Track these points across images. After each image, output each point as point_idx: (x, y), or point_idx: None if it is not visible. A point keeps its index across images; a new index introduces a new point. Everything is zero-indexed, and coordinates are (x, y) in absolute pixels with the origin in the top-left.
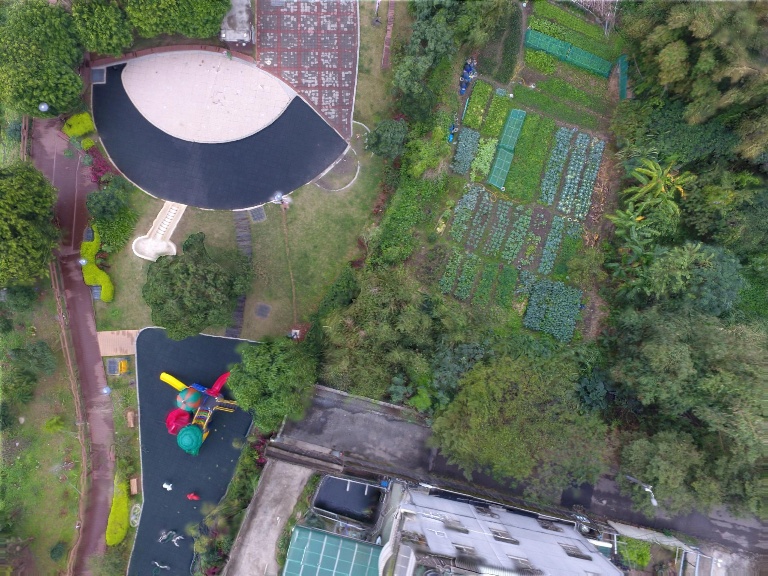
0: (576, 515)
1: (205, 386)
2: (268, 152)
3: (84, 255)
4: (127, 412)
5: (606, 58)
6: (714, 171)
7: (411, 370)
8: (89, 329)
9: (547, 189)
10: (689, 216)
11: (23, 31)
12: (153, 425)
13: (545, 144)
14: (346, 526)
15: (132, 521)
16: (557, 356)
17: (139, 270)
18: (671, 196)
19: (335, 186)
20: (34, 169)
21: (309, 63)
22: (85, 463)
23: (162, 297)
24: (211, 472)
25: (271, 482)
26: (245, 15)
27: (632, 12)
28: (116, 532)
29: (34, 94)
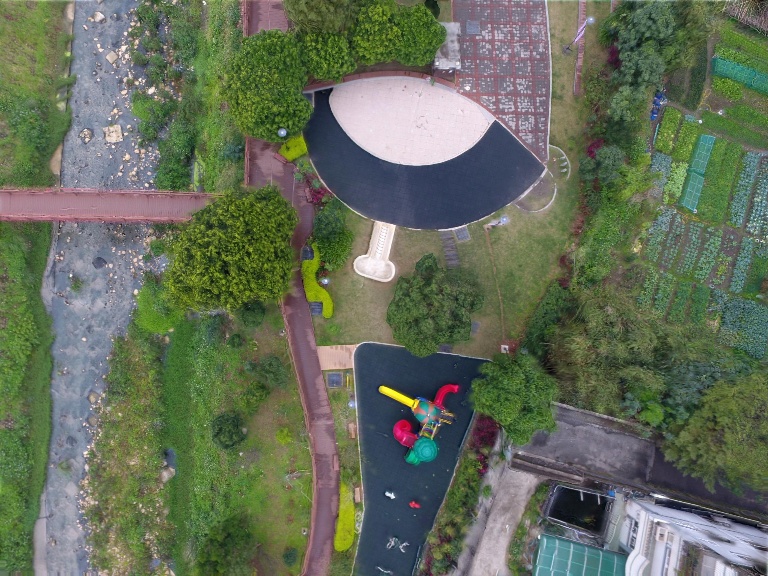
0: None
1: None
2: (470, 174)
3: (305, 273)
4: (348, 423)
5: None
6: None
7: (640, 386)
8: (309, 344)
9: (735, 211)
10: None
11: (263, 60)
12: (372, 436)
13: (733, 168)
14: (579, 534)
15: (355, 528)
16: (757, 372)
17: (360, 288)
18: None
19: (534, 207)
20: None
21: (505, 89)
22: (314, 472)
23: (414, 316)
24: (428, 481)
25: (500, 491)
26: (456, 44)
27: None
28: (345, 539)
29: (276, 121)
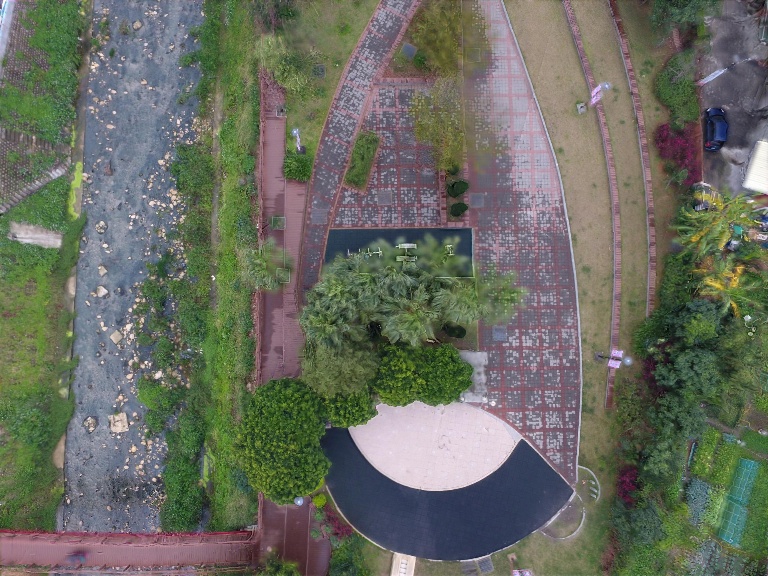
0: None
1: None
2: (495, 500)
3: None
4: None
5: None
6: None
7: None
8: None
9: None
10: None
11: (279, 425)
12: None
13: None
14: None
15: None
16: None
17: None
18: None
19: (561, 534)
20: None
21: (533, 403)
22: None
23: None
24: None
25: None
26: (483, 376)
27: None
28: None
29: (292, 492)
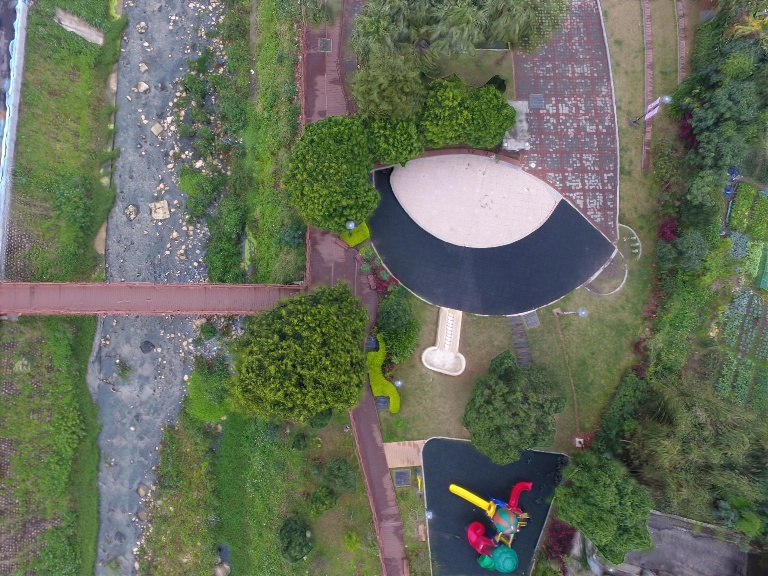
0: None
1: None
2: (538, 256)
3: (370, 366)
4: (418, 525)
5: None
6: None
7: (732, 492)
8: (375, 440)
9: None
10: None
11: (330, 149)
12: (444, 538)
13: None
14: None
15: None
16: None
17: (429, 382)
18: None
19: (605, 290)
20: None
21: (572, 165)
22: None
23: (497, 425)
24: None
25: None
26: (525, 124)
27: None
28: None
29: (344, 213)
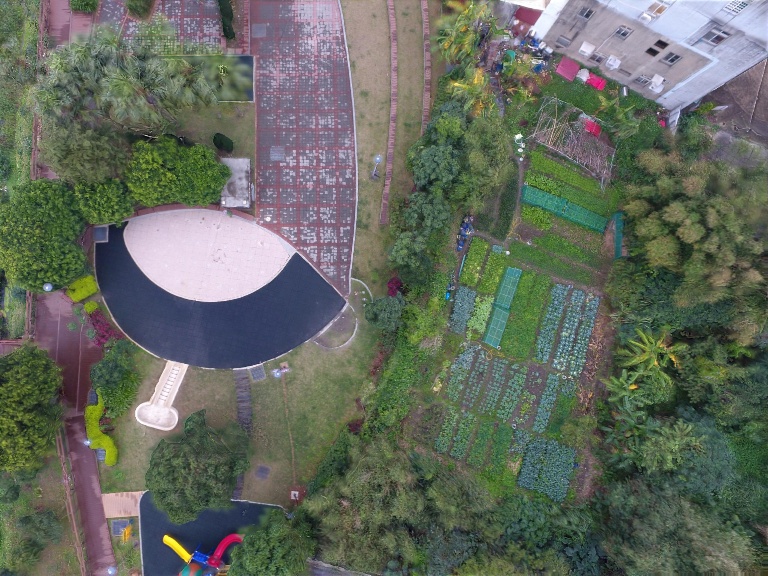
0: None
1: (207, 552)
2: (268, 310)
3: (88, 420)
4: (131, 574)
5: (602, 213)
6: (707, 341)
7: (407, 552)
8: (94, 491)
9: (542, 347)
10: (682, 382)
11: (27, 213)
12: None
13: (540, 301)
14: None
15: None
16: (550, 521)
17: (142, 436)
18: (664, 365)
19: (333, 344)
20: (39, 353)
21: (308, 219)
22: None
23: (164, 488)
24: None
25: None
26: (245, 181)
27: (628, 165)
28: None
29: (38, 276)
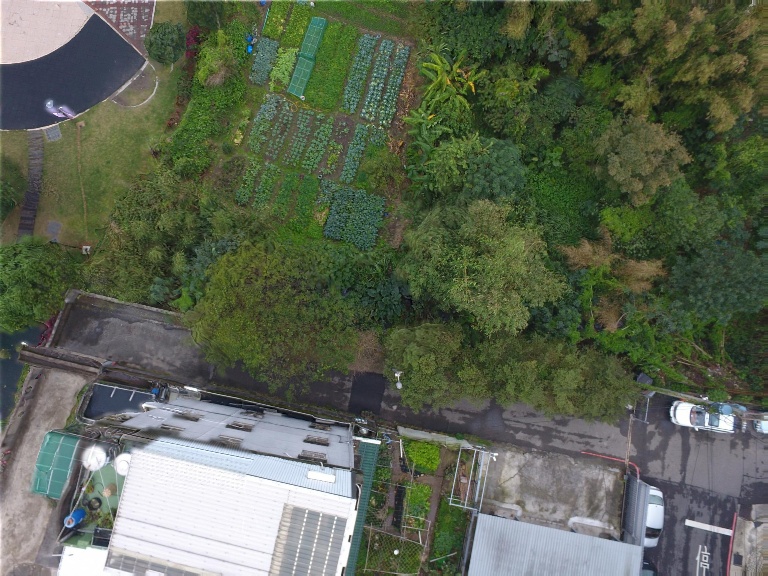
0: (356, 418)
1: None
2: (64, 70)
3: None
4: None
5: None
6: (507, 65)
7: (176, 271)
8: None
9: (349, 97)
10: (487, 114)
11: None
12: None
13: (347, 52)
14: None
15: None
16: (351, 262)
17: None
18: (464, 92)
19: (132, 102)
20: None
21: None
22: None
23: None
24: None
25: (44, 395)
26: None
27: None
28: None
29: None
